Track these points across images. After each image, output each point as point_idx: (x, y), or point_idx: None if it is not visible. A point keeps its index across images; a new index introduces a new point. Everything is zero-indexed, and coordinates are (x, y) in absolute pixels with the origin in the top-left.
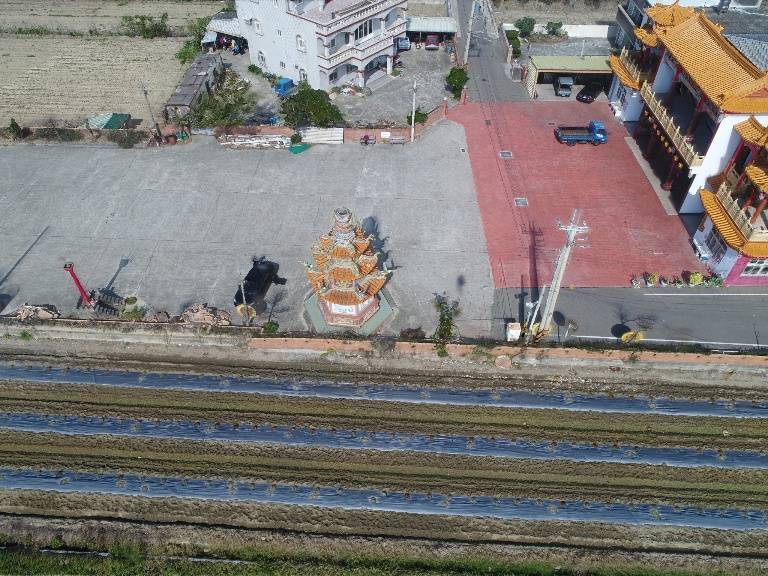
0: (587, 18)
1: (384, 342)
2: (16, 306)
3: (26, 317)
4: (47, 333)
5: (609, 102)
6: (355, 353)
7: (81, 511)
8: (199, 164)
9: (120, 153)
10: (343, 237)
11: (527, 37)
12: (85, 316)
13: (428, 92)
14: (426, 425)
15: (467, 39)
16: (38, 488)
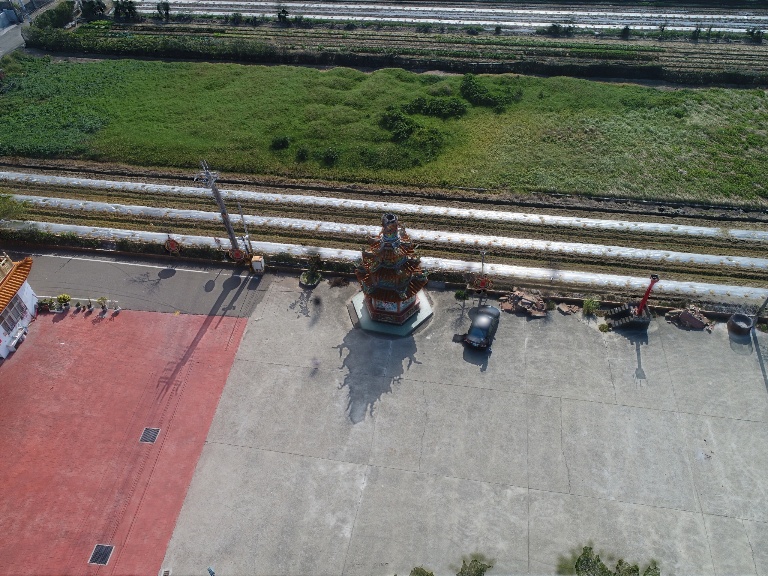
0: None
1: None
2: (718, 331)
3: None
4: None
5: None
6: None
7: None
8: None
9: None
10: None
11: None
12: None
13: None
14: (344, 237)
15: None
16: (593, 219)
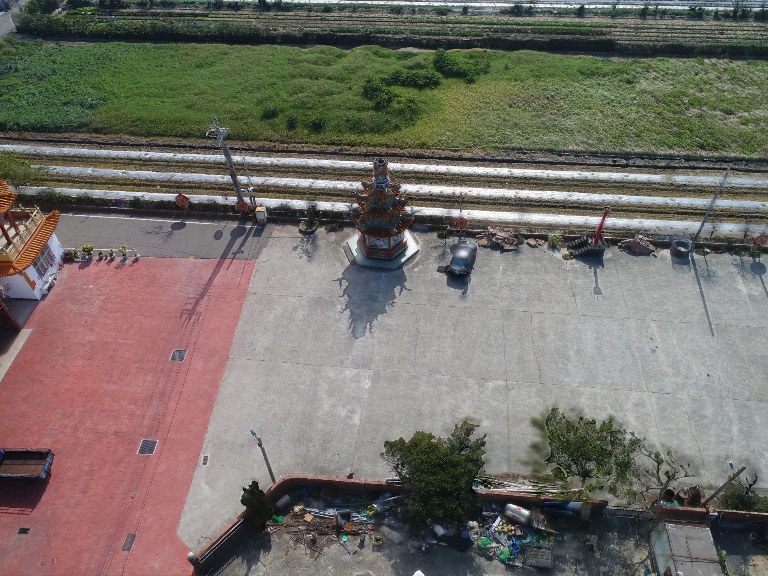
0: None
1: None
2: (662, 255)
3: None
4: None
5: None
6: None
7: None
8: None
9: None
10: None
11: None
12: None
13: None
14: (336, 192)
15: None
16: (555, 171)
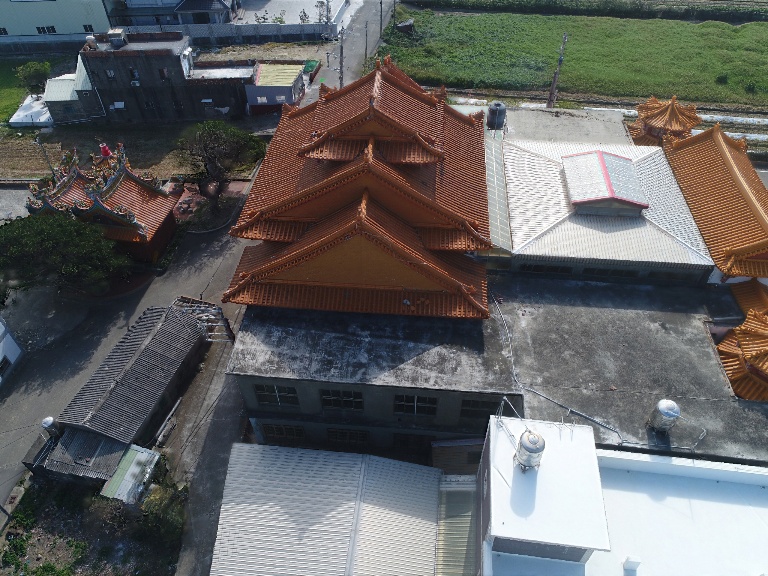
0: None
1: None
2: None
3: None
4: None
5: None
6: None
7: None
8: None
9: None
10: None
11: None
12: None
13: None
14: None
15: None
16: None
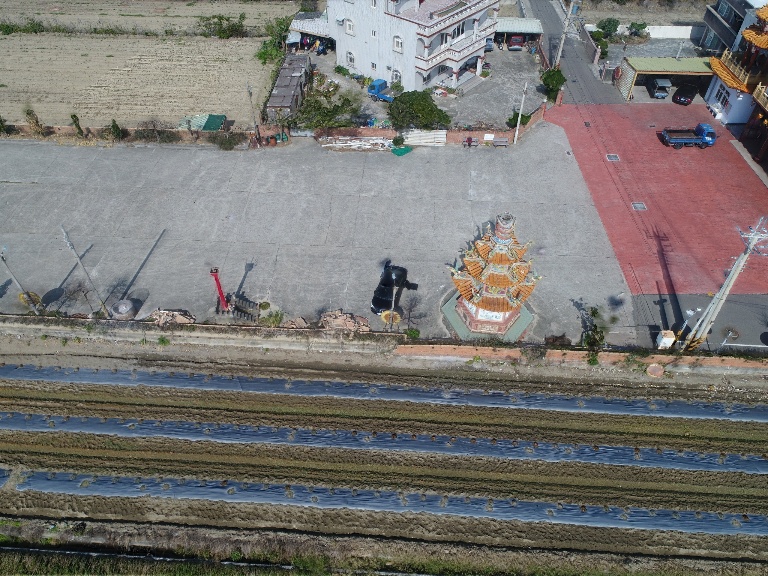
0: (662, 19)
1: (536, 350)
2: (149, 311)
3: (164, 322)
4: (185, 339)
5: (706, 104)
6: (501, 360)
7: (254, 522)
8: (304, 166)
9: (222, 155)
10: (503, 243)
11: (609, 38)
12: (223, 321)
13: (520, 94)
14: (587, 435)
15: (561, 40)
16: (206, 498)
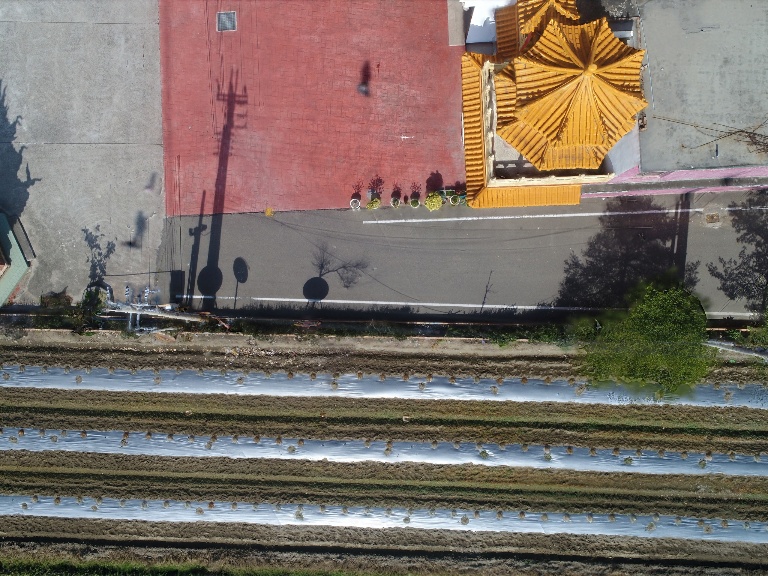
0: None
1: (8, 333)
2: None
3: None
4: None
5: None
6: None
7: None
8: None
9: None
10: None
11: None
12: None
13: None
14: (79, 418)
15: None
16: None
